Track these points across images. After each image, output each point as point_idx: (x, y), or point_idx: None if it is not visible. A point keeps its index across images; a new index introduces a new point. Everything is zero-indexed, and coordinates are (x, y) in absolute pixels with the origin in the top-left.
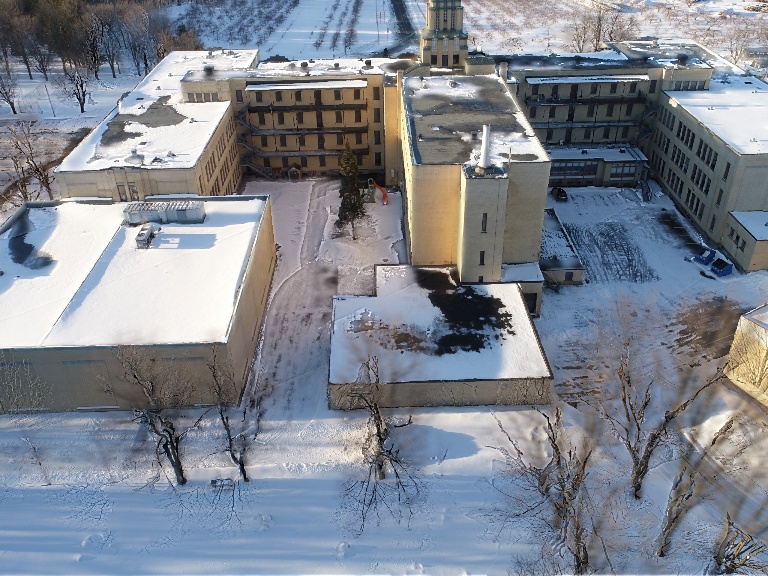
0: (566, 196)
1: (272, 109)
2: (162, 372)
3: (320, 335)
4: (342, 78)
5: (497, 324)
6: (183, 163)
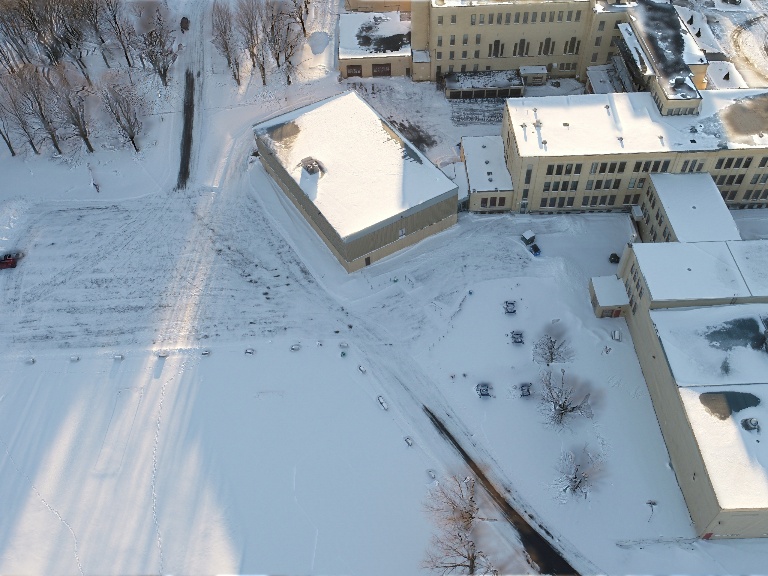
0: None
1: None
2: None
3: None
4: None
5: (378, 49)
6: None
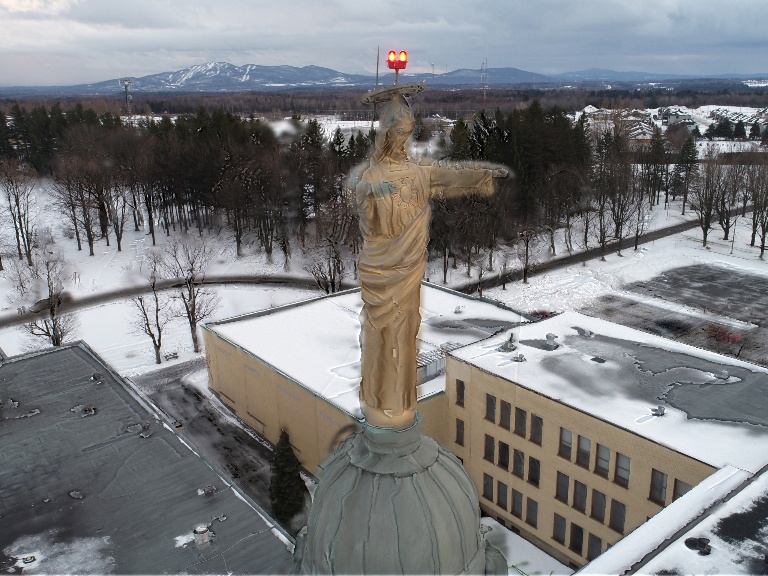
0: None
1: None
2: None
3: None
4: None
5: None
6: (473, 353)
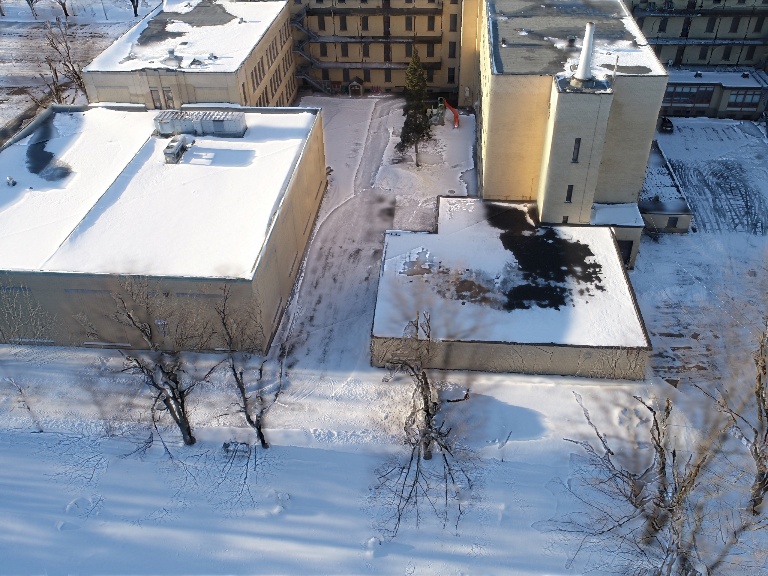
0: (672, 127)
1: (333, 11)
2: (177, 309)
3: (369, 275)
4: None
5: (583, 276)
6: (224, 67)
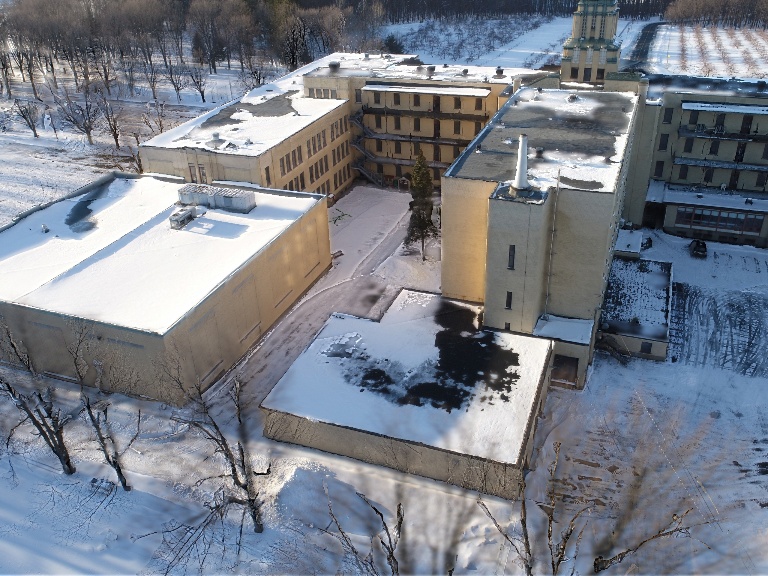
0: (704, 252)
1: (386, 112)
2: (109, 353)
3: None
4: (464, 85)
5: (494, 384)
6: (251, 151)
